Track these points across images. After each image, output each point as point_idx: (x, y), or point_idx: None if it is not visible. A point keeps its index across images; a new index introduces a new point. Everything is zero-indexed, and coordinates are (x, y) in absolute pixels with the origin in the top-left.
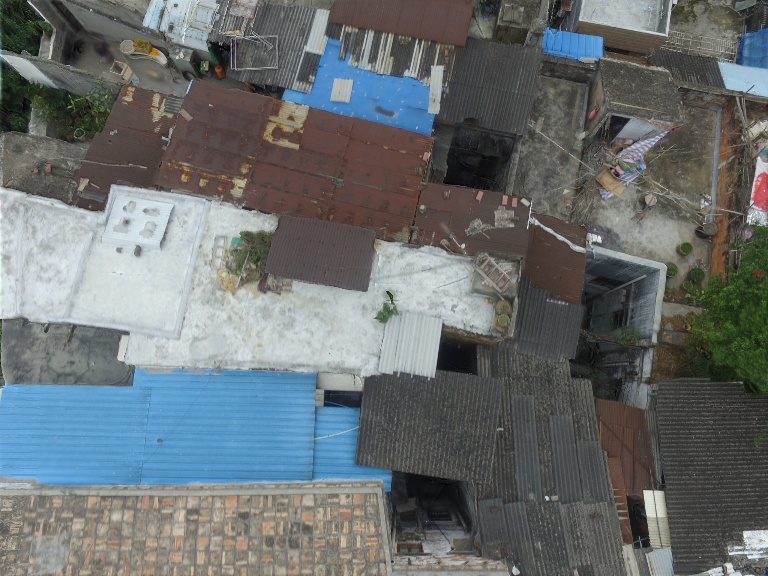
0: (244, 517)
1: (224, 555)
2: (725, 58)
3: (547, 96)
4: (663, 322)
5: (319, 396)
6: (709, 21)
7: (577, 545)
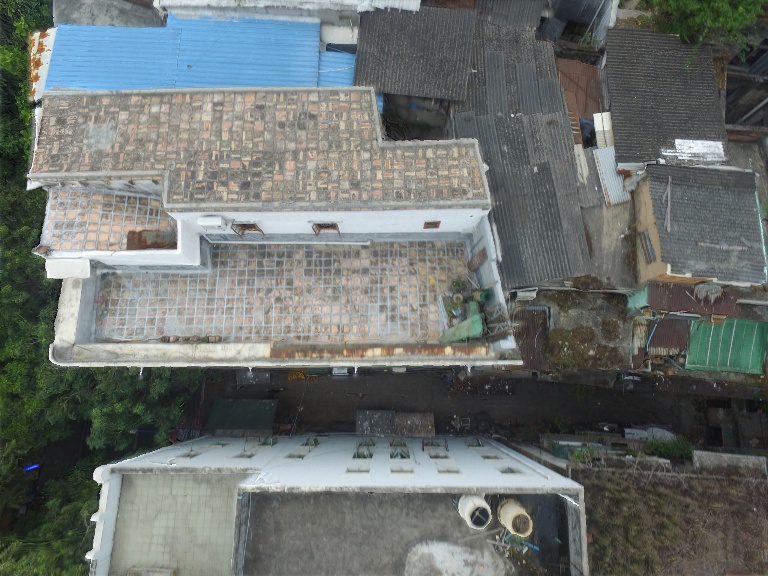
0: (261, 108)
1: (244, 134)
2: None
3: None
4: (618, 22)
5: (322, 44)
6: None
7: (537, 147)
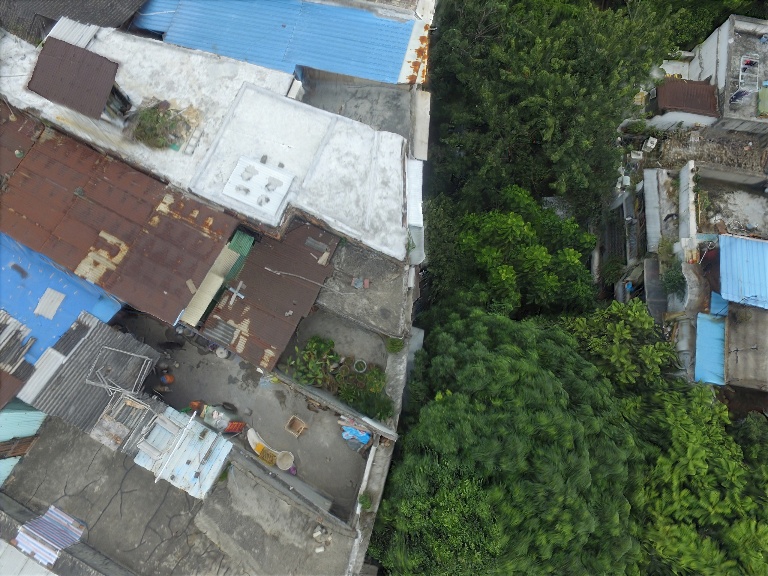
0: None
1: None
2: None
3: None
4: None
5: None
6: None
7: None
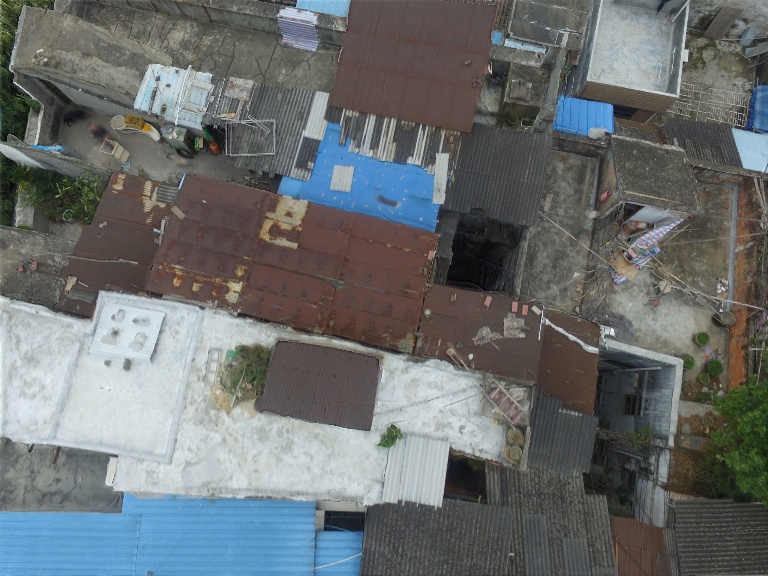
0: None
1: None
2: (736, 111)
3: (556, 171)
4: (680, 423)
5: (319, 519)
6: (719, 68)
7: None
